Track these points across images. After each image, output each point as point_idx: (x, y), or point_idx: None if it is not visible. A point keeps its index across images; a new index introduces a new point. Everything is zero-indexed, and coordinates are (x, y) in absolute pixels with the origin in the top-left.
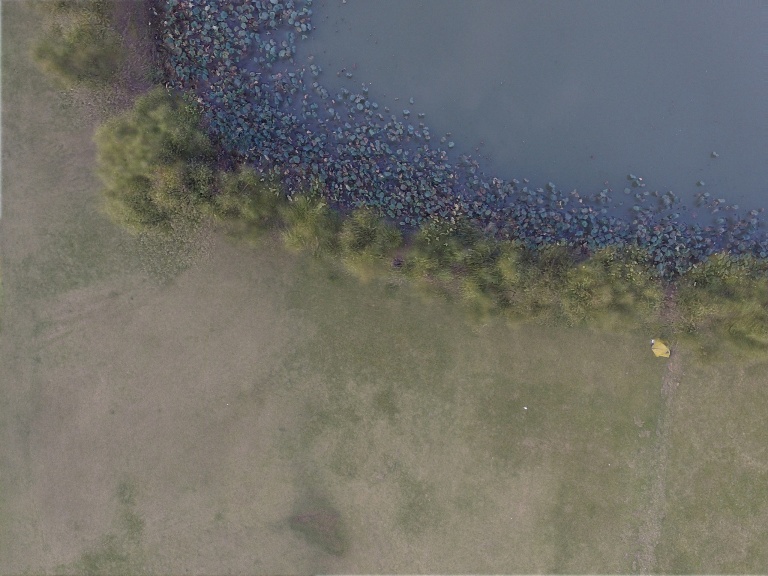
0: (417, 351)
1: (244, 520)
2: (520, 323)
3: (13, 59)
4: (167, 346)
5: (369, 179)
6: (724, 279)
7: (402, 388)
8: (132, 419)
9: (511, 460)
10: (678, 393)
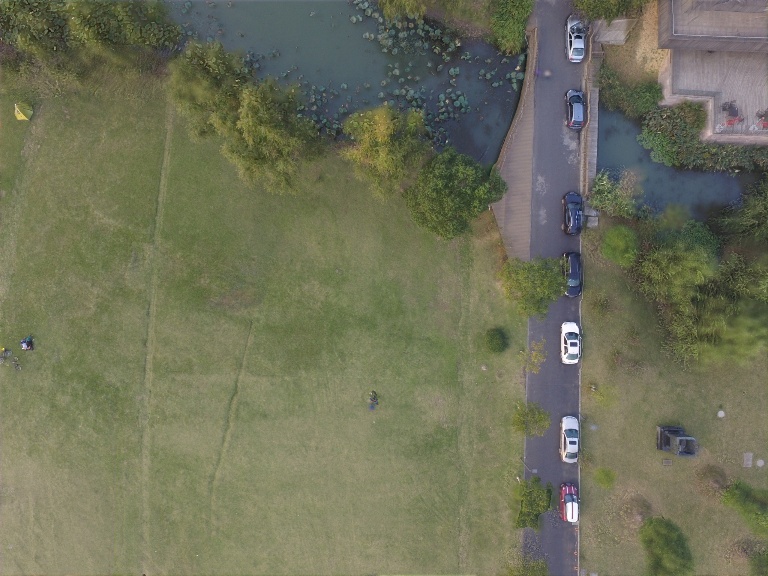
0: None
1: None
2: None
3: None
4: None
5: None
6: (84, 43)
7: None
8: None
9: None
10: (38, 155)
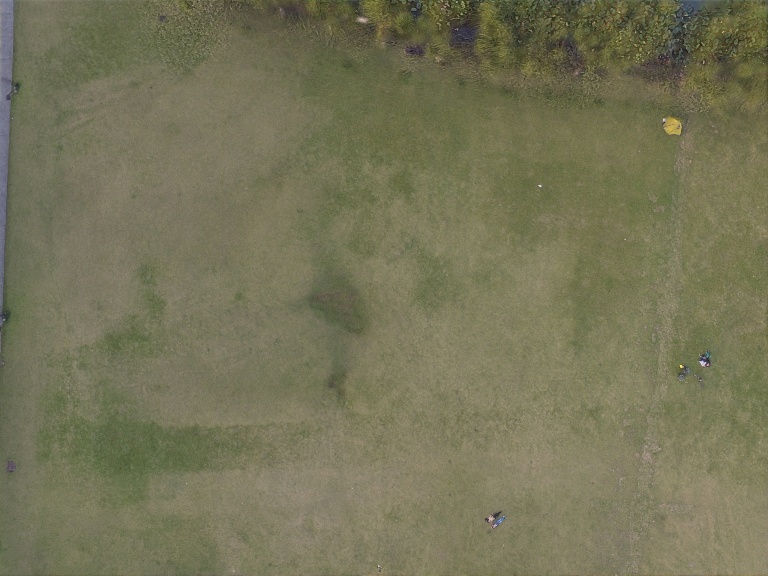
0: (431, 133)
1: (264, 299)
2: (532, 106)
3: None
4: (186, 132)
5: None
6: (732, 57)
7: (417, 169)
8: (153, 203)
9: (527, 236)
10: (691, 170)
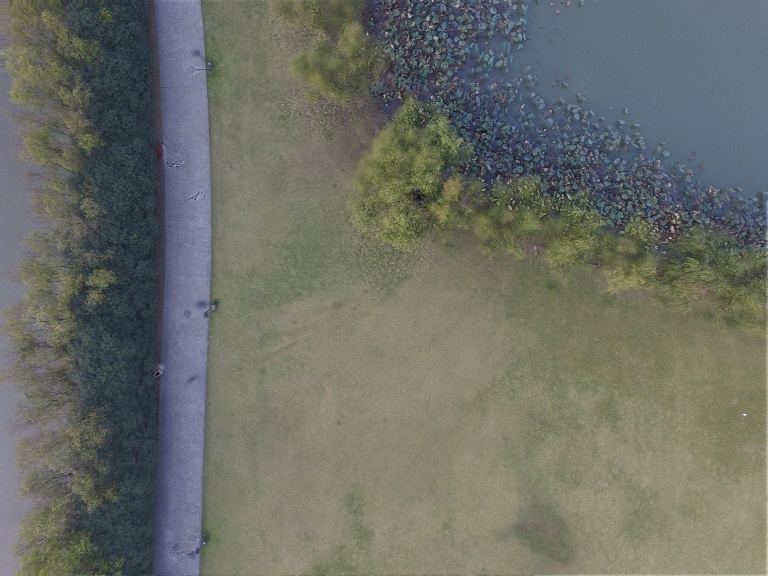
0: (637, 359)
1: (470, 529)
2: (736, 330)
3: (232, 70)
4: (391, 356)
5: (590, 188)
6: None
7: (623, 396)
8: (358, 429)
9: (732, 466)
10: None
